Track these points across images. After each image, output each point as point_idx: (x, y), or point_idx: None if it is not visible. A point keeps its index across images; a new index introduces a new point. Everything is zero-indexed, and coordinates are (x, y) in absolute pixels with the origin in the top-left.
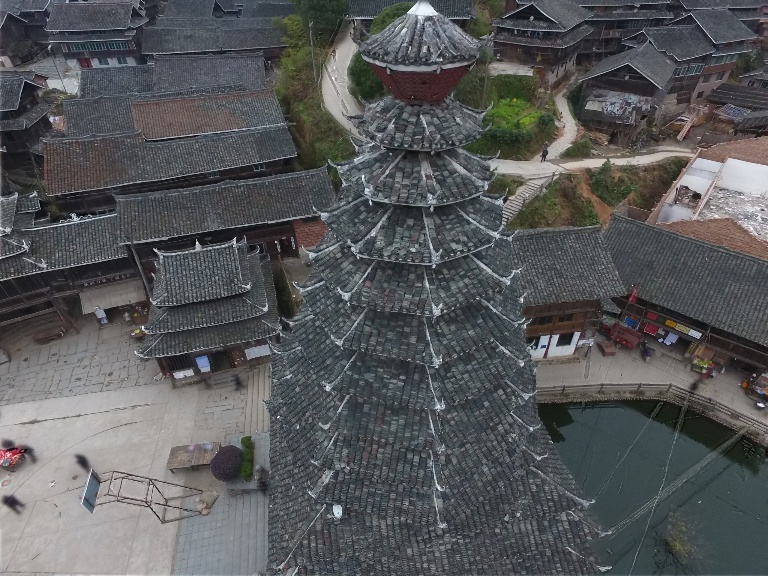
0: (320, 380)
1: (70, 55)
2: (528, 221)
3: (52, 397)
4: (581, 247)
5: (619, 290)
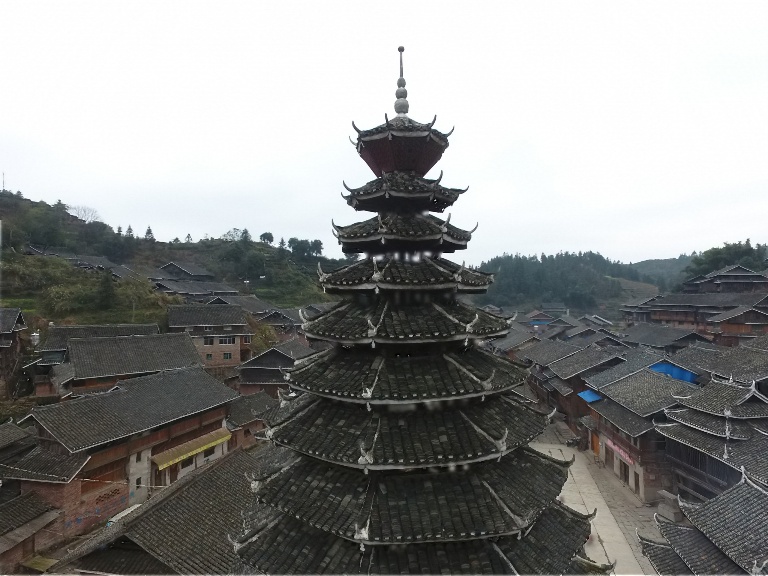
0: None
1: None
2: None
3: (632, 547)
4: None
5: None
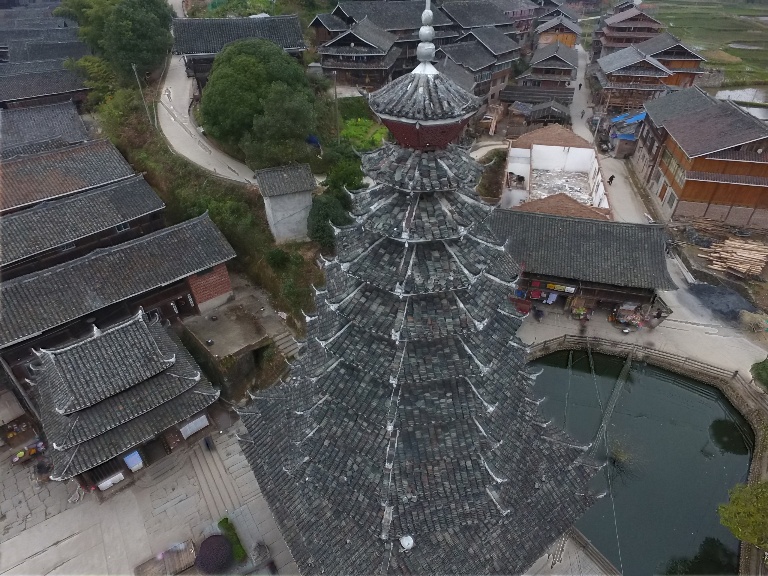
0: (376, 423)
1: None
2: None
3: None
4: None
5: (516, 269)
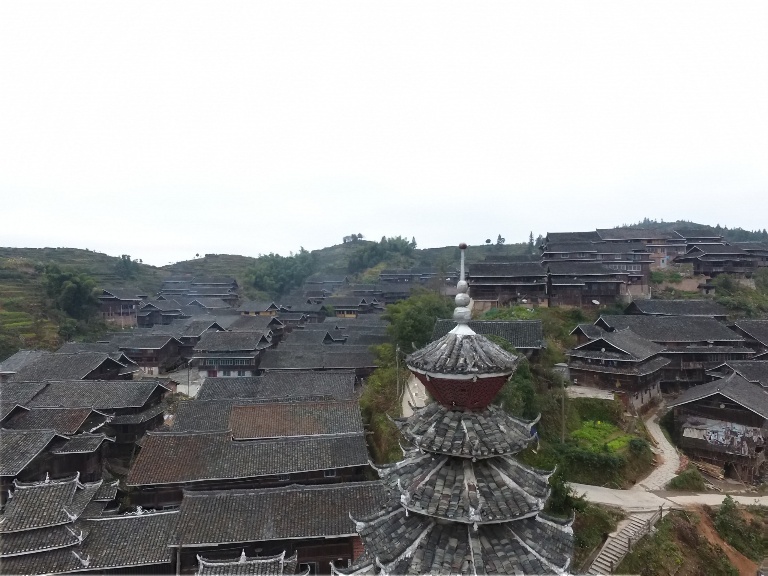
0: None
1: (204, 368)
2: (640, 570)
3: None
4: None
5: None
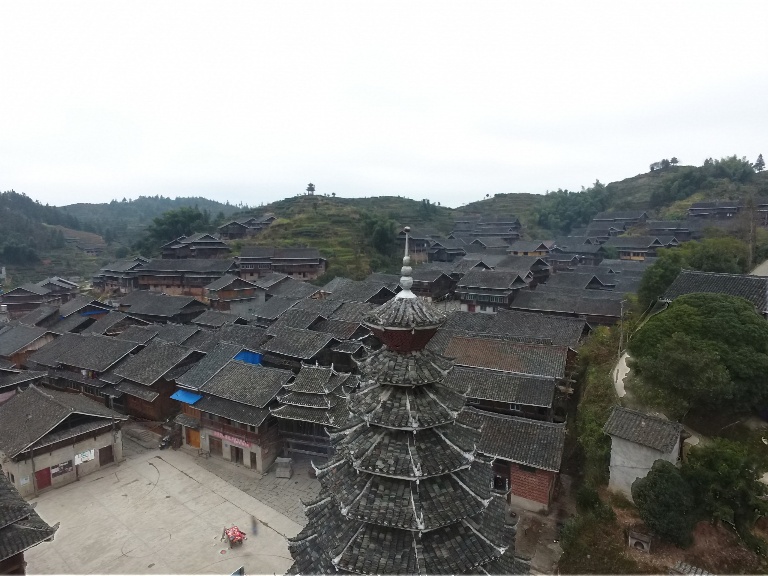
0: None
1: (465, 301)
2: None
3: (286, 515)
4: None
5: None
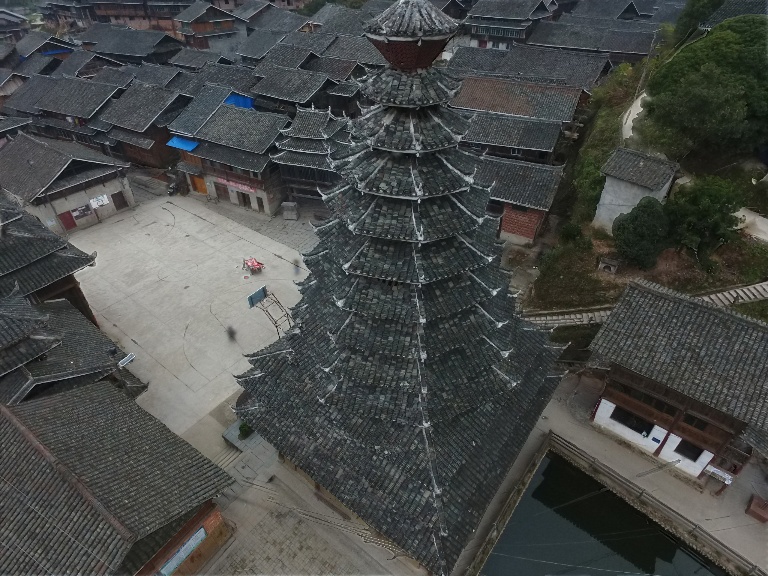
0: None
1: (475, 36)
2: None
3: (297, 249)
4: (759, 350)
5: None
